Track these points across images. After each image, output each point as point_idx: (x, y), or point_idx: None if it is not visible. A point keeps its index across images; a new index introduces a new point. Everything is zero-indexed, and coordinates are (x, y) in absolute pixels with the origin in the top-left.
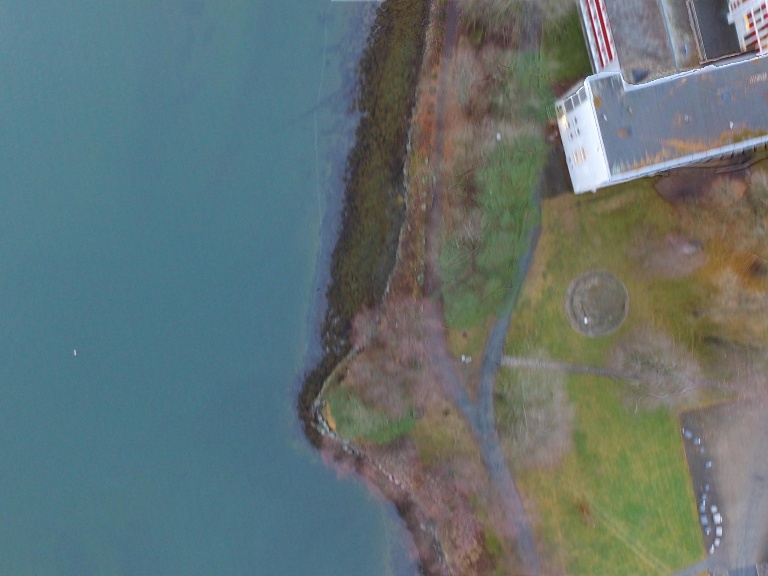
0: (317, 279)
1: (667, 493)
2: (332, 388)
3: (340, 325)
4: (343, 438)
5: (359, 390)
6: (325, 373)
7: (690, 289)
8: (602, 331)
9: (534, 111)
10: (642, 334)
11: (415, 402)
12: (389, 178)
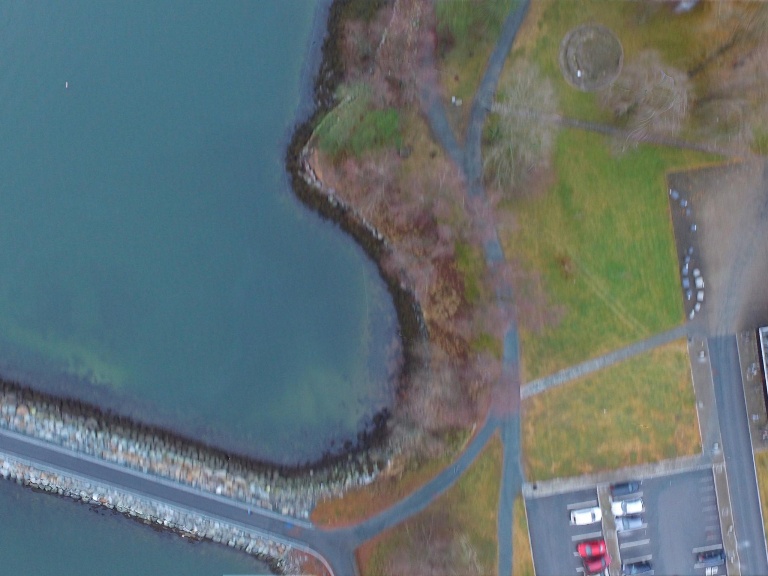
0: (313, 33)
1: (650, 254)
2: (321, 135)
3: (333, 79)
4: (329, 187)
5: (348, 135)
6: (315, 124)
7: (686, 45)
8: (595, 85)
9: None
10: (635, 88)
11: (403, 141)
12: None
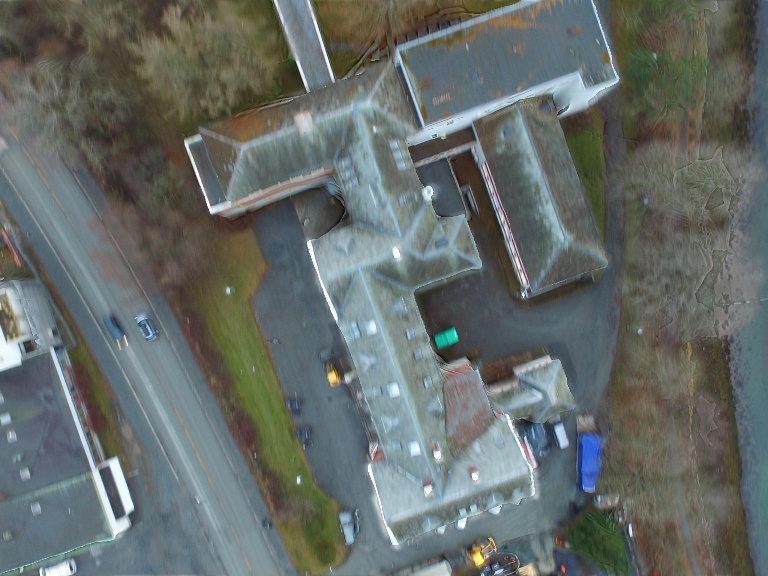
0: None
1: None
2: None
3: None
4: None
5: None
6: None
7: None
8: None
9: (647, 63)
10: None
11: None
12: (719, 43)
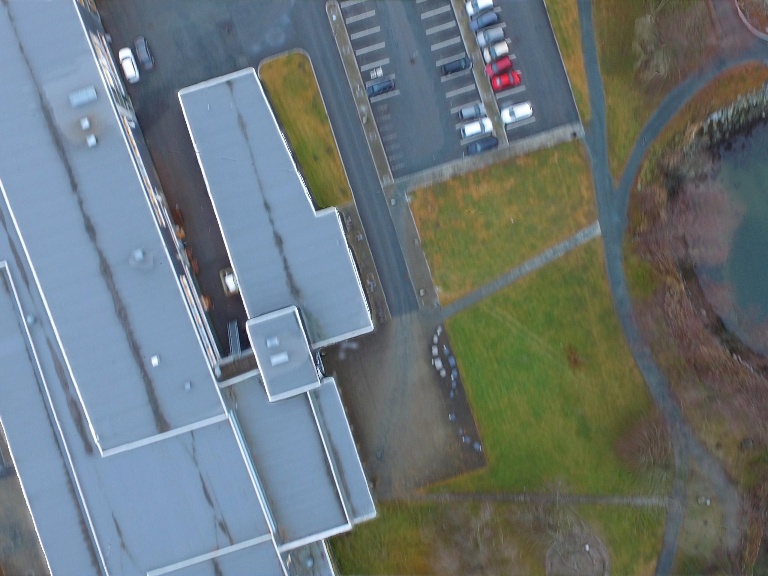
0: None
1: (491, 384)
2: None
3: None
4: None
5: None
6: None
7: None
8: None
9: None
10: (537, 544)
11: (750, 454)
12: None
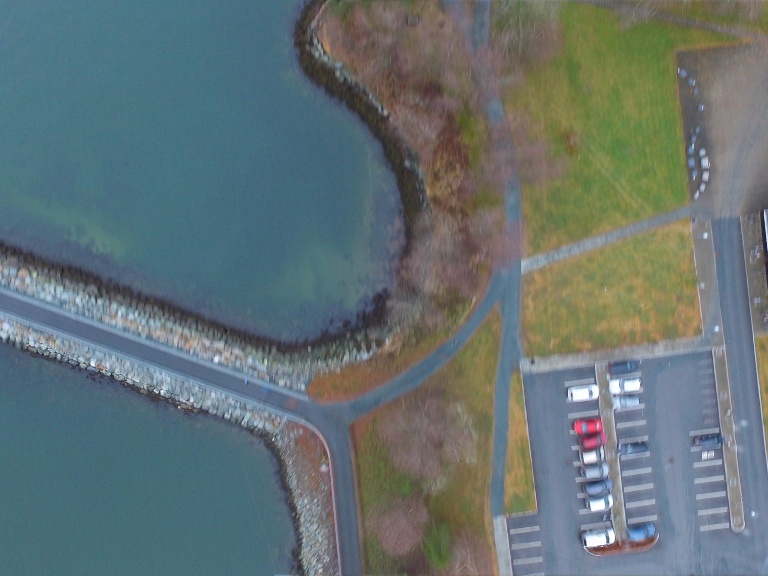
0: None
1: (656, 133)
2: (330, 8)
3: None
4: (336, 60)
5: (357, 7)
6: None
7: None
8: None
9: None
10: None
11: (411, 10)
12: None
